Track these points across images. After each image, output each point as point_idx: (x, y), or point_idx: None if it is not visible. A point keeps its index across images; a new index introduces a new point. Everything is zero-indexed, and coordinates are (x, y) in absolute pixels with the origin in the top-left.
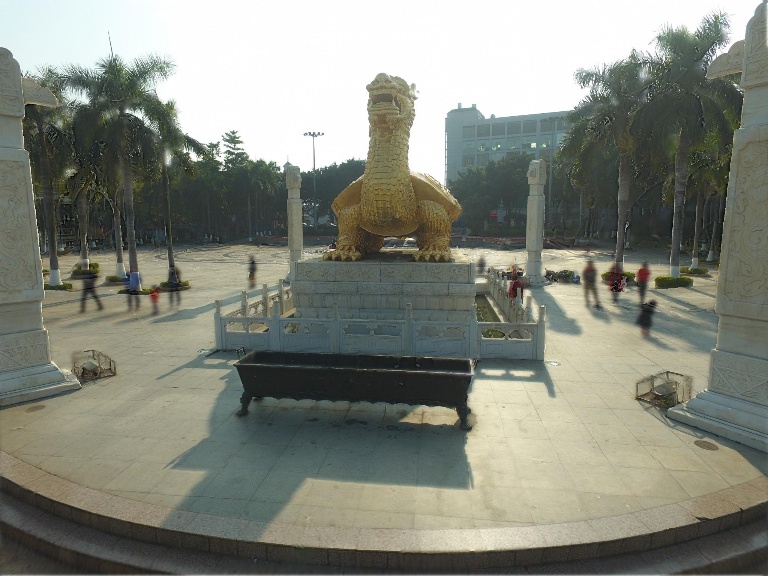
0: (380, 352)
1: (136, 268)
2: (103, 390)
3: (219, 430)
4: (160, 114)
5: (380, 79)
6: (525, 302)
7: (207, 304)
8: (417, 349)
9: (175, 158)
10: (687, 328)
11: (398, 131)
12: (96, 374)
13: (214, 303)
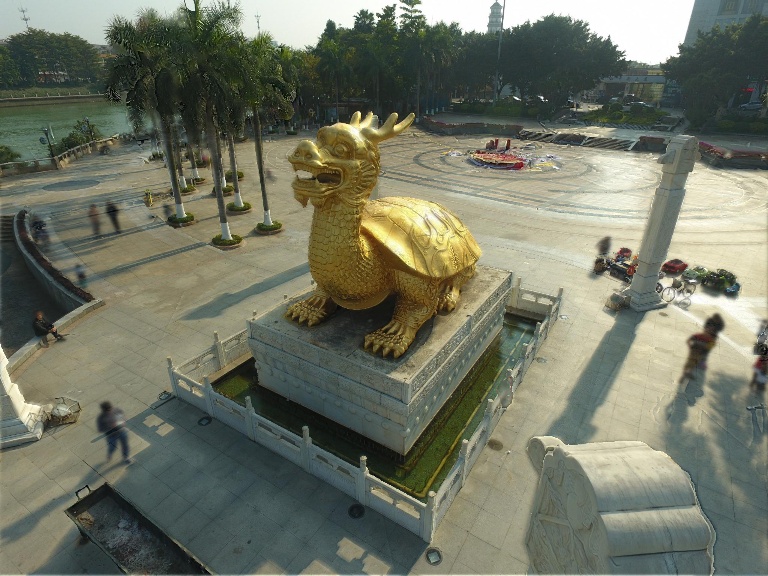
0: (285, 456)
1: (225, 219)
2: (47, 449)
3: (48, 564)
4: (235, 65)
5: (300, 151)
6: (572, 359)
7: (250, 286)
8: (314, 470)
9: (265, 100)
10: (735, 518)
11: (339, 205)
12: (60, 421)
13: (257, 284)
